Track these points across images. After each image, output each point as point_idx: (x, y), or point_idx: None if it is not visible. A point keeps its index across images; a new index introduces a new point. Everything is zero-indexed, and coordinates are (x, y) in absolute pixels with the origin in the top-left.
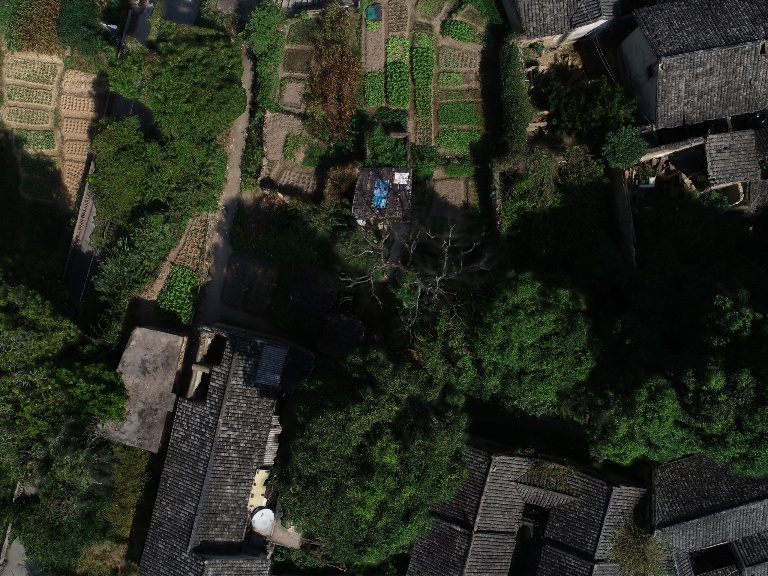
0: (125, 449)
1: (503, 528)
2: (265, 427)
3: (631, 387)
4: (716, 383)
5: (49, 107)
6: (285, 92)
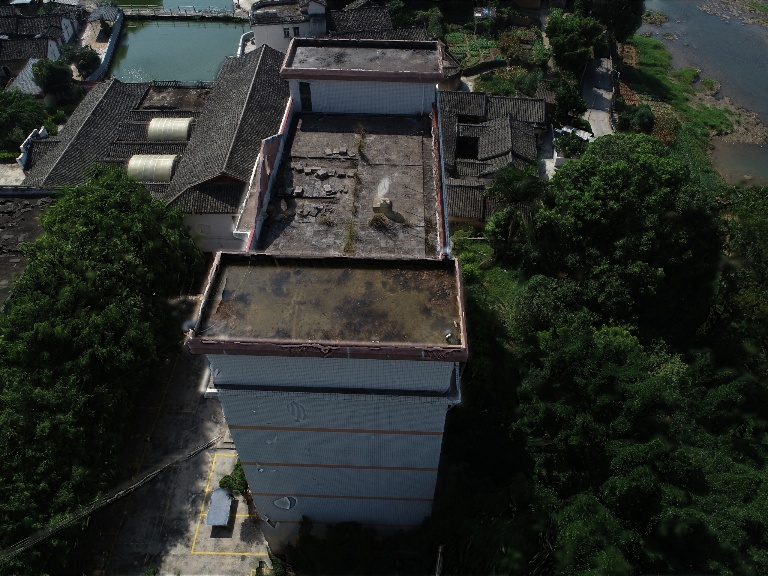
0: None
1: None
2: None
3: None
4: None
5: None
6: None
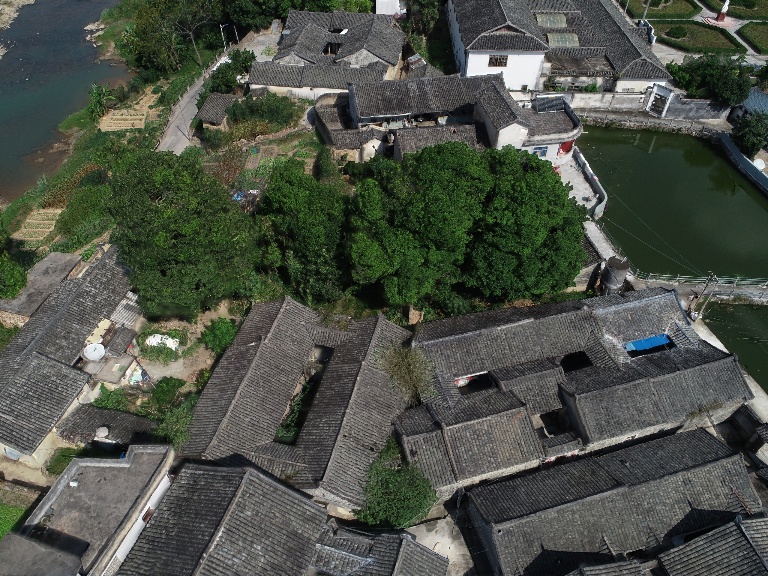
0: (2, 340)
1: (293, 354)
2: (120, 295)
3: None
4: (395, 165)
5: (48, 230)
6: None
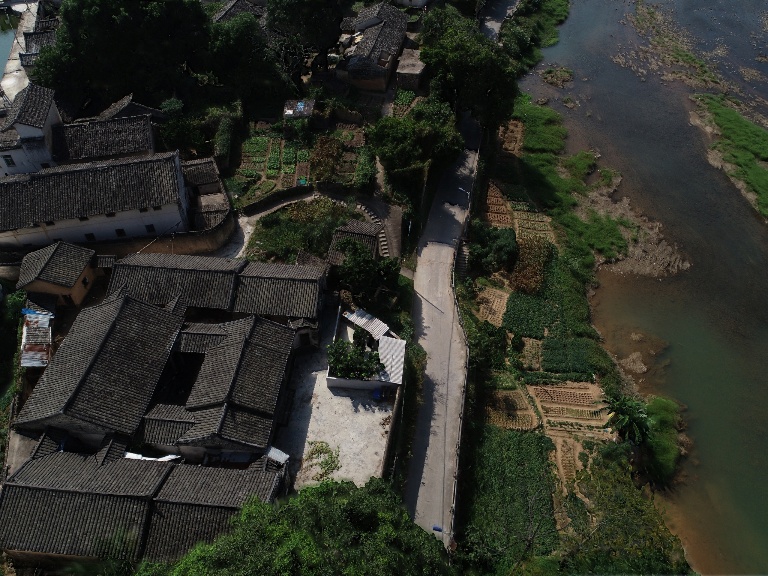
0: None
1: None
2: None
3: (198, 8)
4: None
5: None
6: (354, 157)
